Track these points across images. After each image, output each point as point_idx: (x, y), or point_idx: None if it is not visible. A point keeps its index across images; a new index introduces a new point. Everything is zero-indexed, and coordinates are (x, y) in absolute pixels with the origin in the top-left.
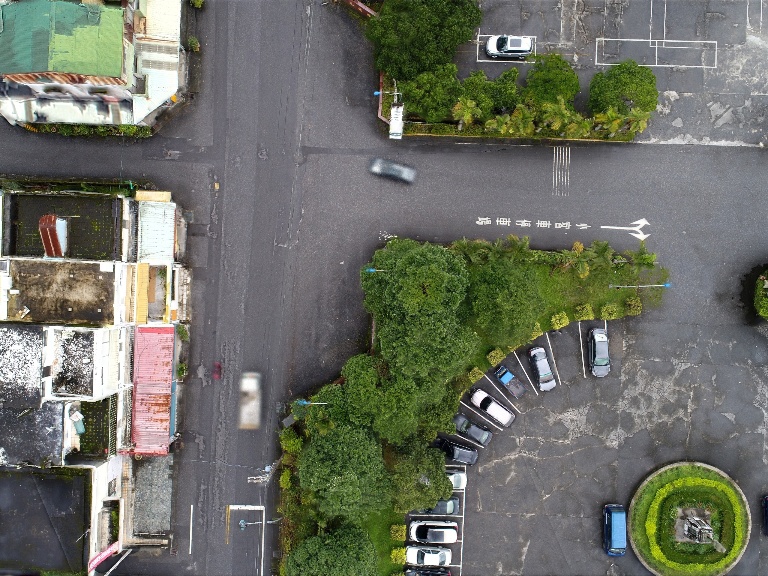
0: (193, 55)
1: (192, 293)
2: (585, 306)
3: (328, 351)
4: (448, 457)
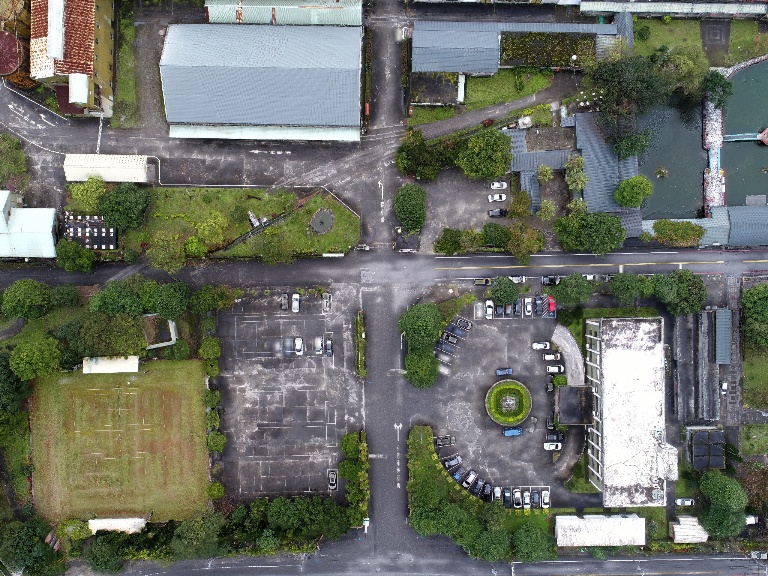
0: None
1: None
2: (429, 448)
3: (451, 542)
4: (488, 496)
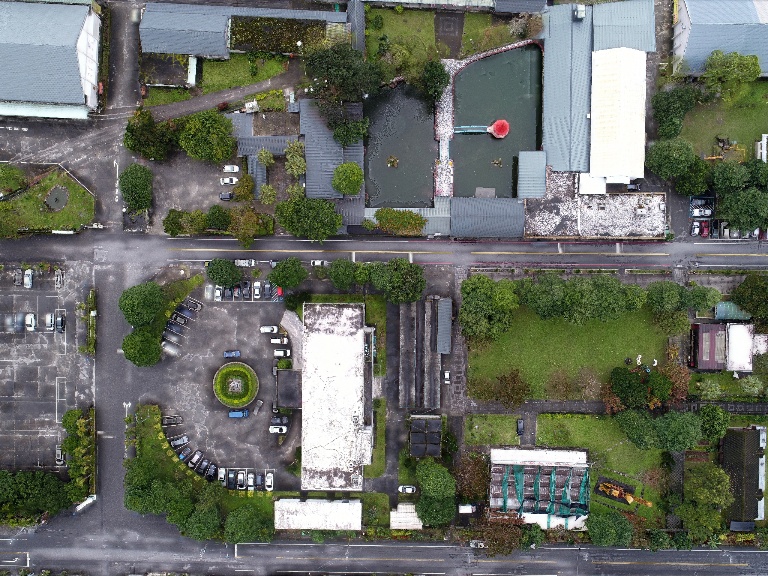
0: (67, 573)
1: (156, 572)
2: (155, 427)
3: None
4: (212, 477)
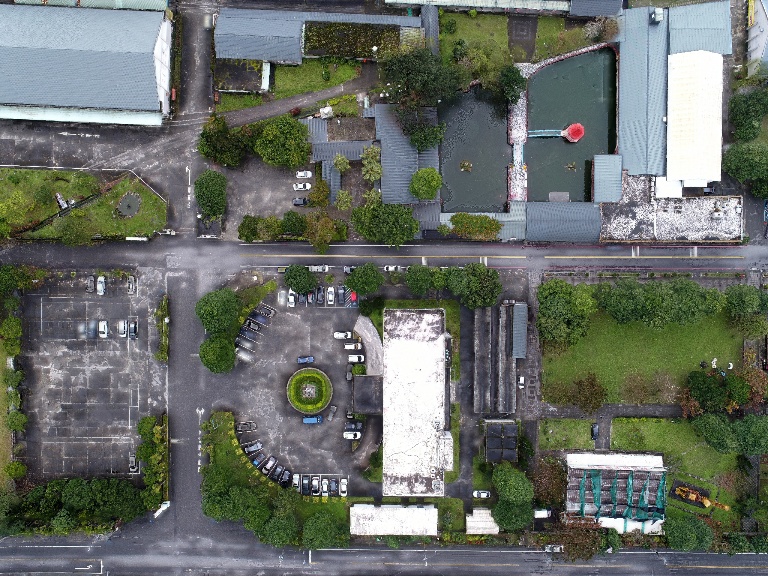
0: None
1: None
2: (229, 434)
3: None
4: (287, 483)
